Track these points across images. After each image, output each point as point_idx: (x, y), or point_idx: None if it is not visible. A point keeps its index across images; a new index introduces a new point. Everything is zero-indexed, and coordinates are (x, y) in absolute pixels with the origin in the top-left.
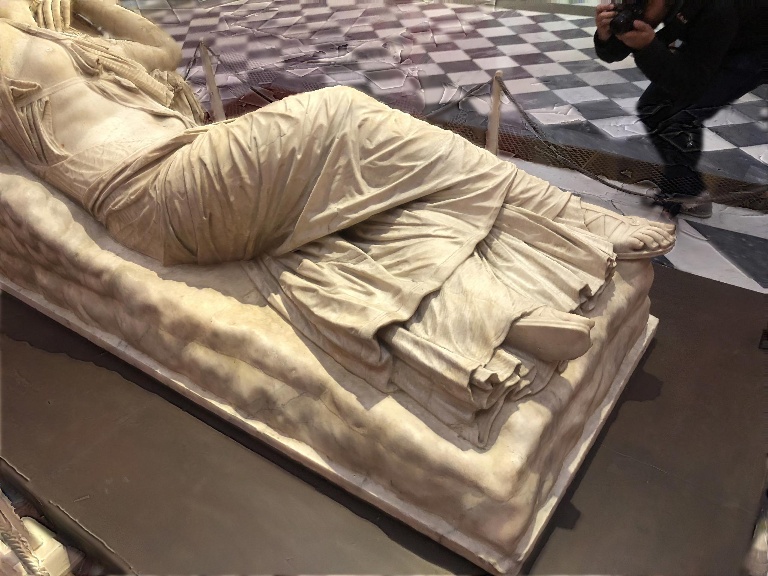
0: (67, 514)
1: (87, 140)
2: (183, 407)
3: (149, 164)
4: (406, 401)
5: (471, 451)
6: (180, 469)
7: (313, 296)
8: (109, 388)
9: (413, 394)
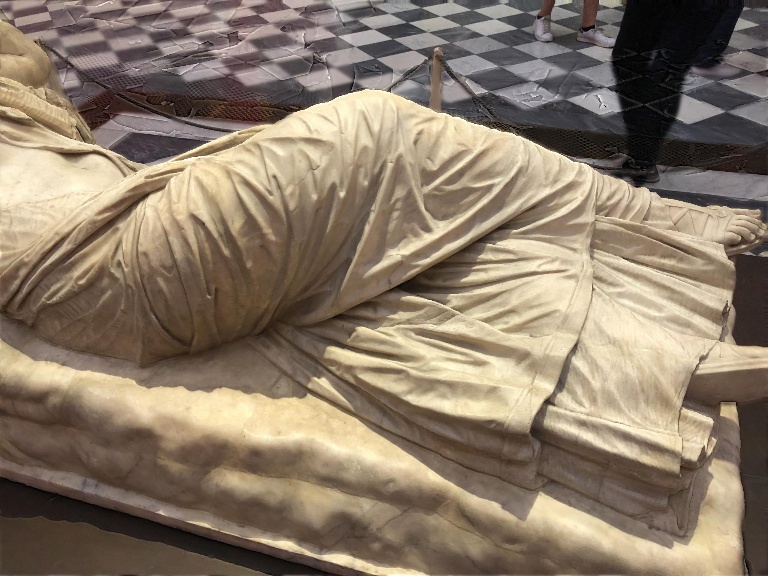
0: None
1: None
2: (208, 552)
3: (98, 230)
4: (564, 495)
5: (677, 545)
6: None
7: (399, 379)
8: (85, 551)
9: (575, 485)
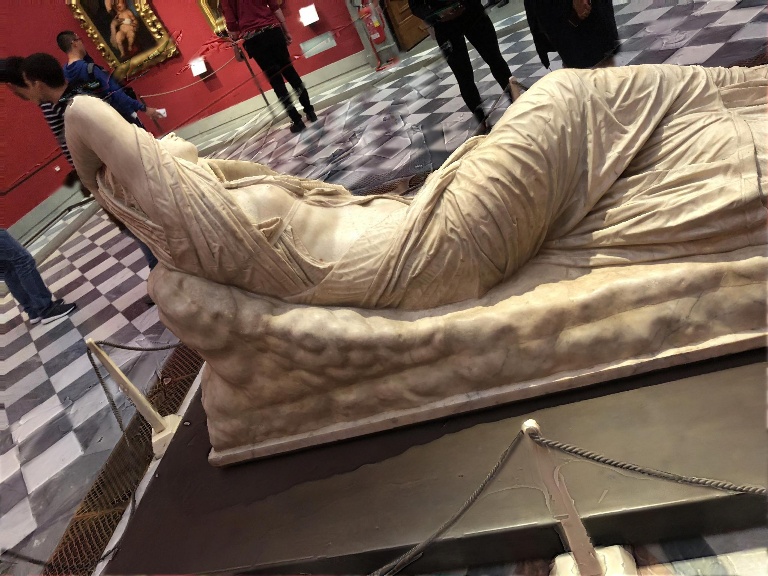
0: (608, 513)
1: (341, 242)
2: (574, 400)
3: (427, 219)
4: None
5: None
6: (642, 427)
7: (656, 219)
8: (492, 435)
9: None
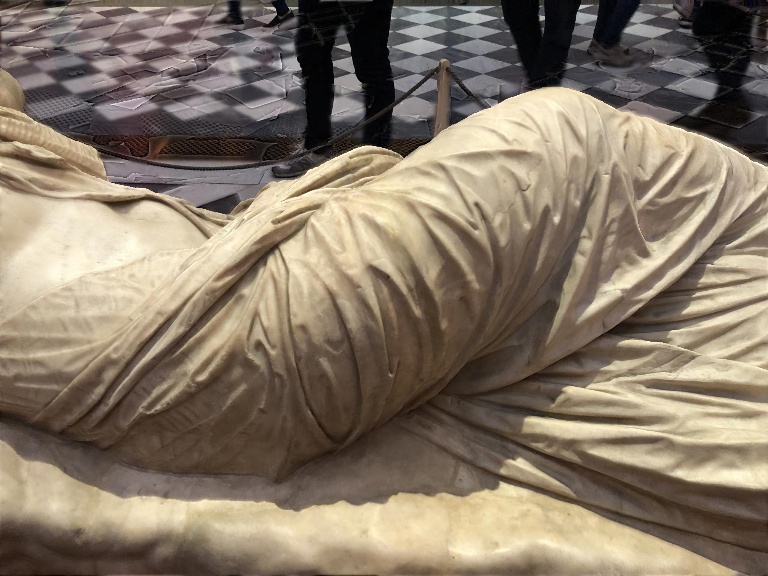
0: None
1: (16, 286)
2: None
3: (216, 302)
4: None
5: None
6: None
7: (655, 449)
8: None
9: None
